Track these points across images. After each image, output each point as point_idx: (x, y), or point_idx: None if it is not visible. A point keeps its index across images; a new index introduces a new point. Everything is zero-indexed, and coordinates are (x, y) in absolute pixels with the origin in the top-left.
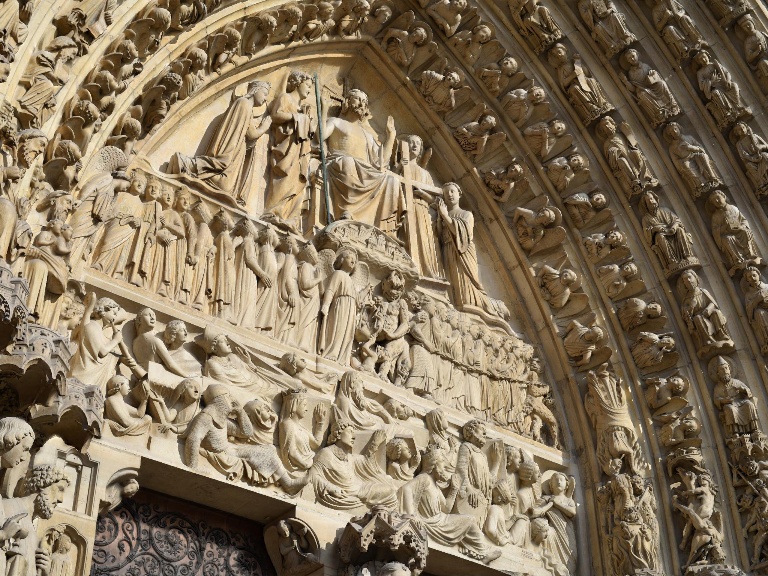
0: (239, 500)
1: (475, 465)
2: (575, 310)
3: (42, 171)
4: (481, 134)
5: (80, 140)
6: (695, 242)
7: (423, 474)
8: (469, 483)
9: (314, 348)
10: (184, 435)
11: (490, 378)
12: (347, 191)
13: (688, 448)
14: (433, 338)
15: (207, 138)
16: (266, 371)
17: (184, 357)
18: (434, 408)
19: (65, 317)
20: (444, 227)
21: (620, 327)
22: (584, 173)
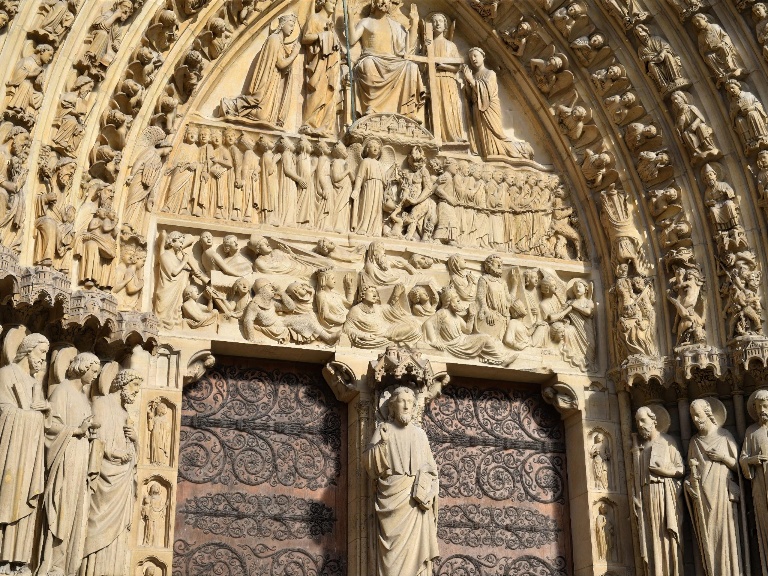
0: (295, 354)
1: (491, 292)
2: (590, 139)
3: (88, 174)
4: (491, 2)
5: (118, 138)
6: (686, 62)
7: (440, 310)
8: (487, 307)
9: (348, 227)
10: (242, 319)
11: (513, 214)
12: (368, 89)
13: (678, 249)
14: (456, 193)
15: (251, 74)
16: (304, 257)
17: (238, 261)
18: (457, 252)
19: (132, 263)
20: (472, 88)
21: (626, 149)
22: (583, 19)
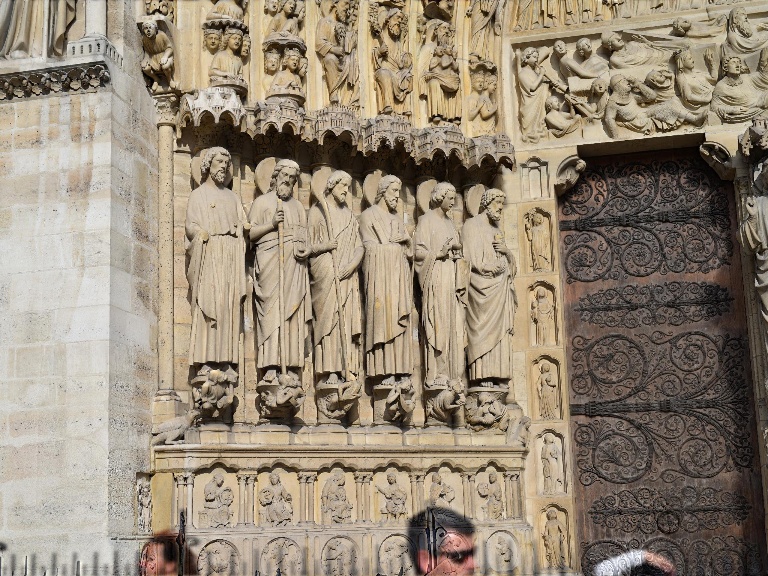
0: (667, 142)
1: None
2: None
3: (423, 18)
4: None
5: None
6: None
7: None
8: None
9: None
10: (604, 118)
11: None
12: None
13: None
14: None
15: None
16: (660, 43)
17: (593, 63)
18: None
19: (484, 89)
20: None
21: None
22: None
